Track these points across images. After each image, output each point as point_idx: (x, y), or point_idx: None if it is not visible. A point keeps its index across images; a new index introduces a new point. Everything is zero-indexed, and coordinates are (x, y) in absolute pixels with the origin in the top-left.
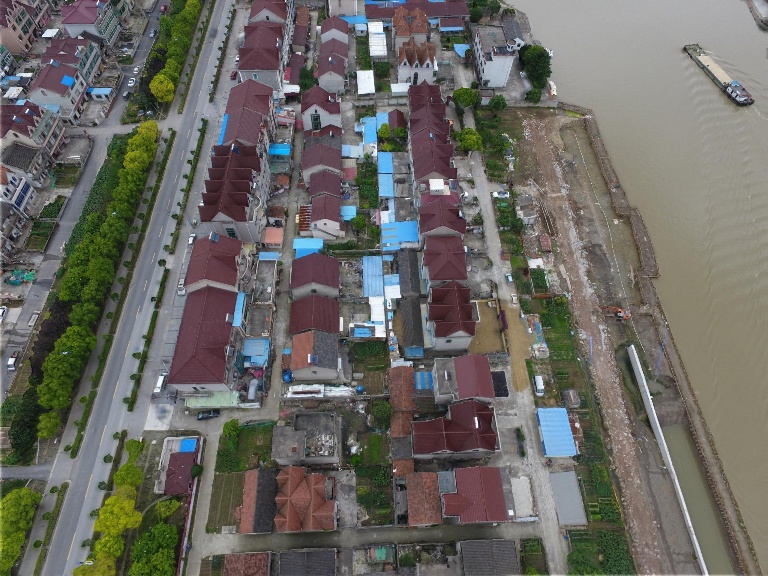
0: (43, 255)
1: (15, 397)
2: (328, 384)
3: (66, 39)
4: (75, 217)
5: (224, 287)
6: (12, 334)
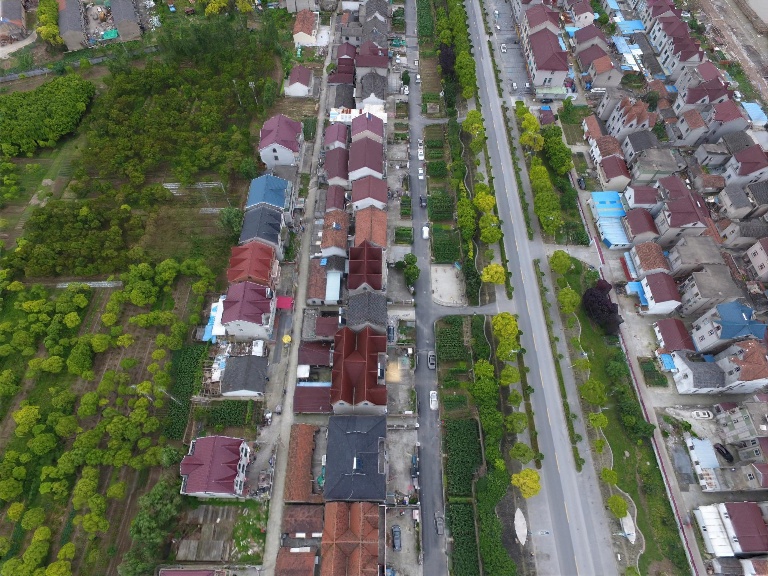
0: (404, 35)
1: (428, 93)
2: None
3: None
4: (413, 19)
5: (553, 30)
6: (408, 68)
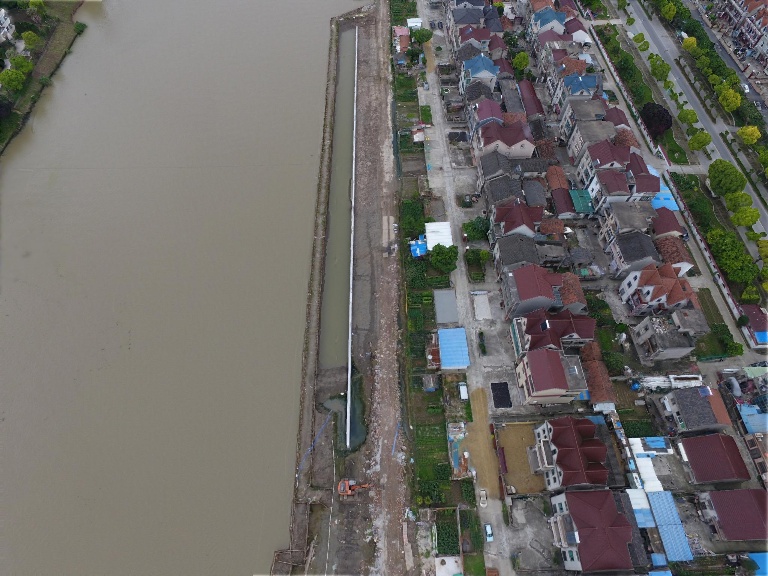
0: None
1: None
2: (667, 392)
3: None
4: None
5: None
6: None
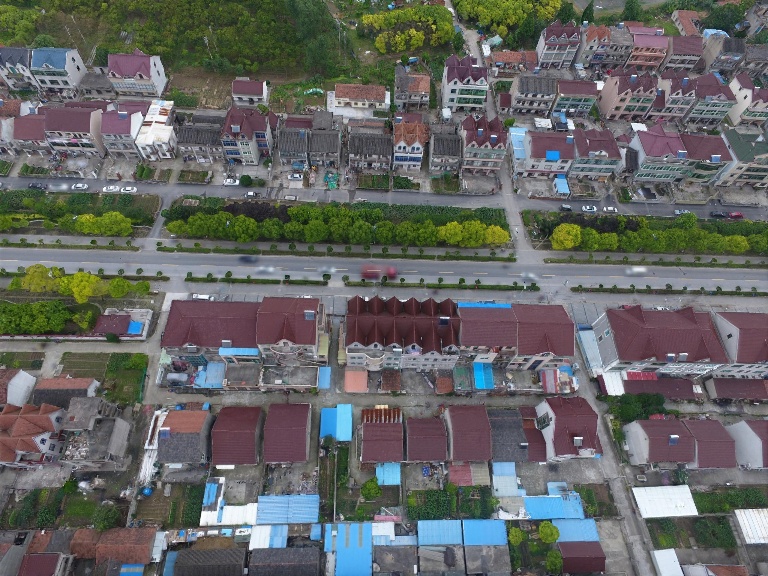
0: (355, 189)
1: (222, 203)
2: None
3: (609, 139)
4: (397, 201)
5: None
6: (279, 188)
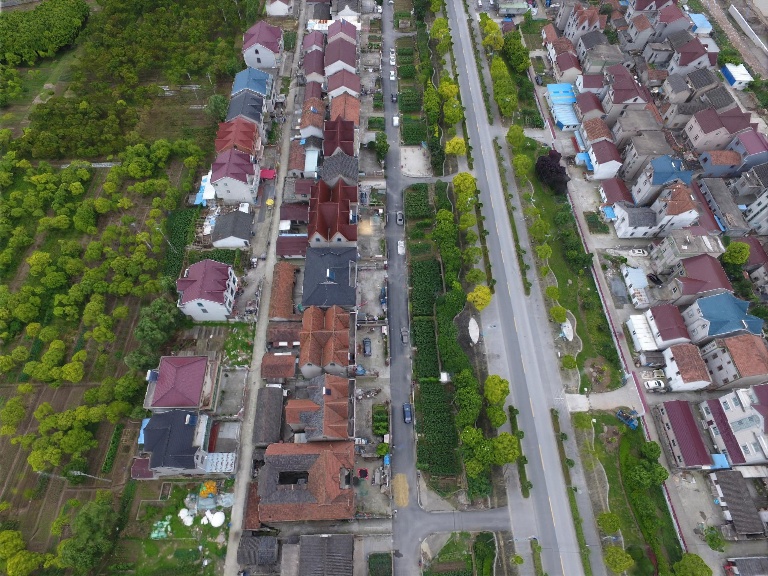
0: None
1: (400, 11)
2: None
3: None
4: None
5: None
6: None
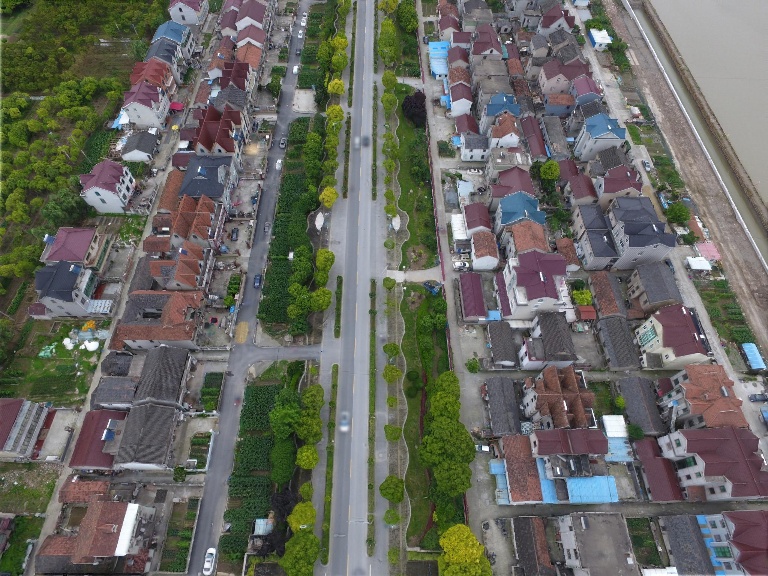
0: None
1: None
2: None
3: None
4: None
5: None
6: None
